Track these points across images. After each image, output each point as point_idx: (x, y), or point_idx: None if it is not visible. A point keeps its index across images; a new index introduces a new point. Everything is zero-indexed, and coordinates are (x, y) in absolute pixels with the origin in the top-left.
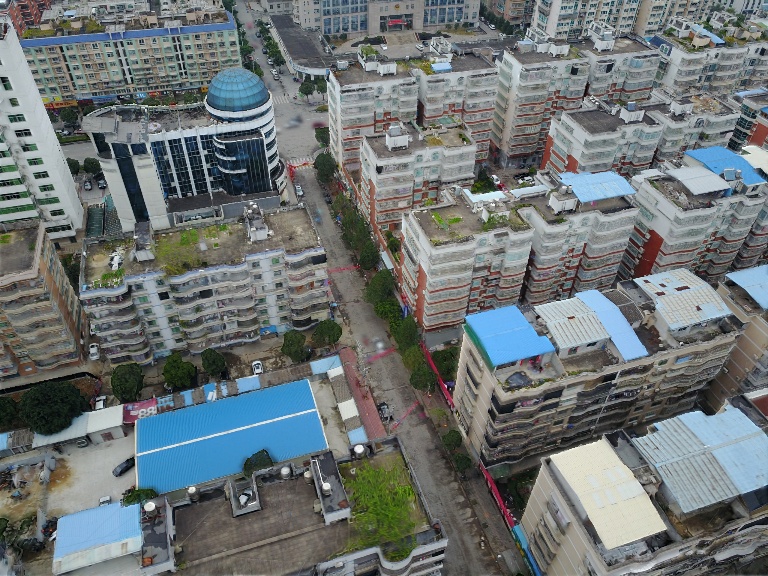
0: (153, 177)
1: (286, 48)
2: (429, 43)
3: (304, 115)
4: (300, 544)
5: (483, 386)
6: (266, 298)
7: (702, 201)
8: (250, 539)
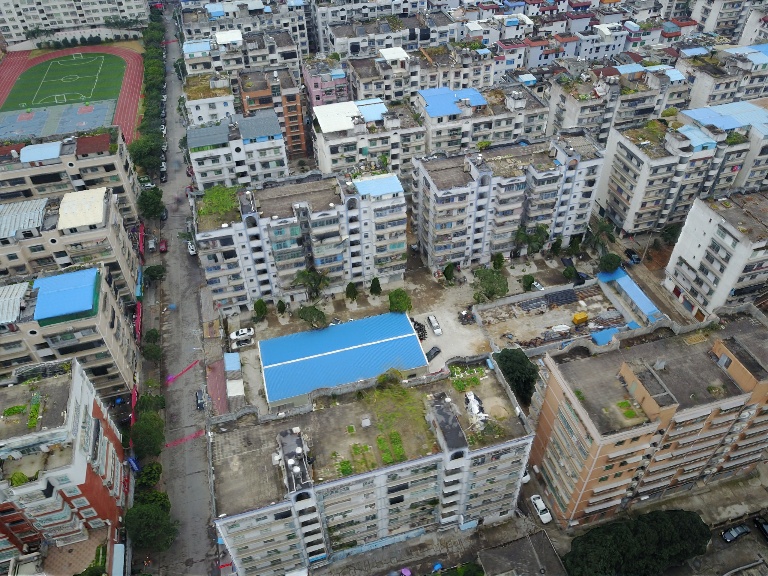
0: None
1: None
2: None
3: None
4: (271, 195)
5: None
6: None
7: None
8: (298, 197)
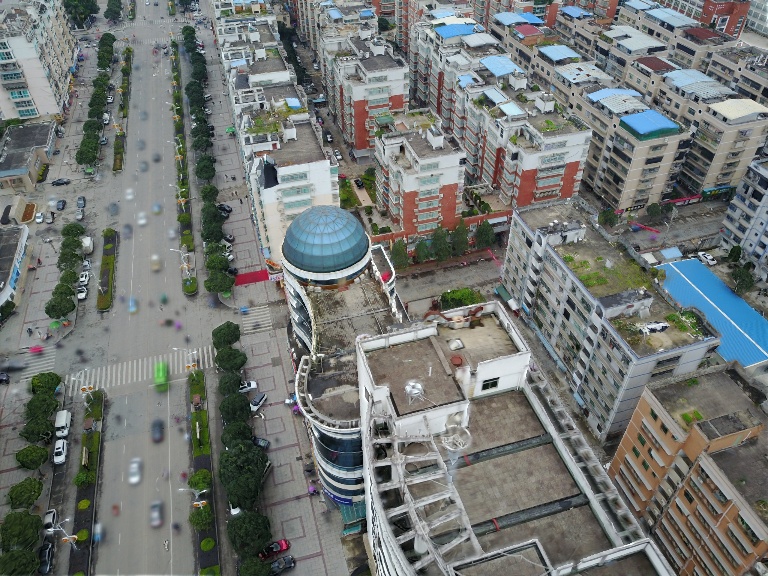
0: None
1: None
2: None
3: (113, 324)
4: None
5: (665, 154)
6: None
7: (492, 48)
8: None
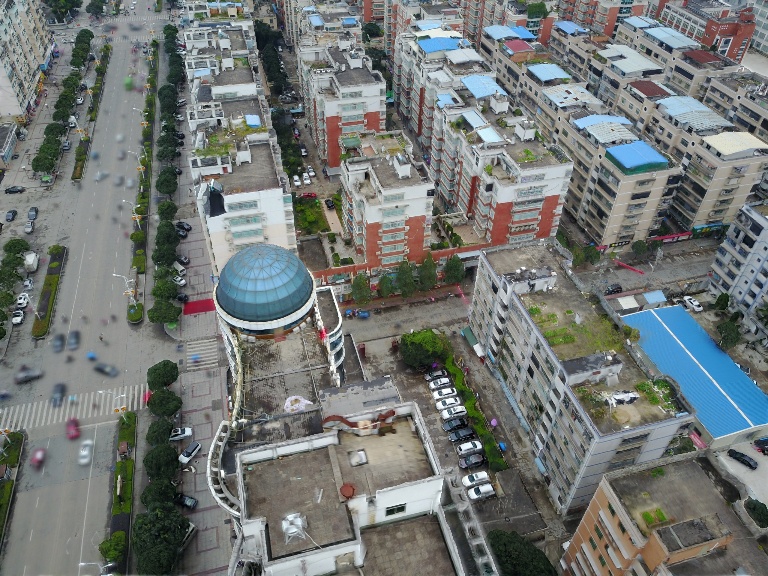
0: None
1: None
2: None
3: (46, 354)
4: None
5: (653, 189)
6: None
7: (477, 65)
8: None
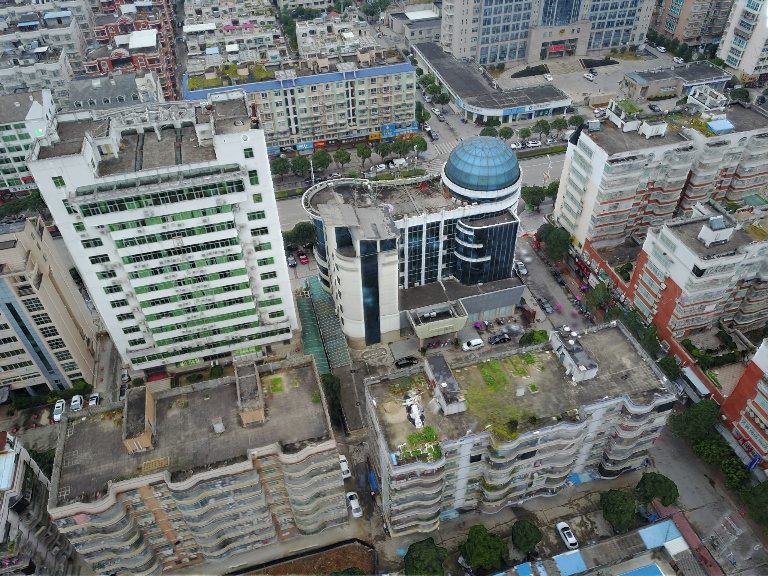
0: (395, 274)
1: (448, 84)
2: (597, 71)
3: None
4: None
5: None
6: (581, 447)
7: None
8: None
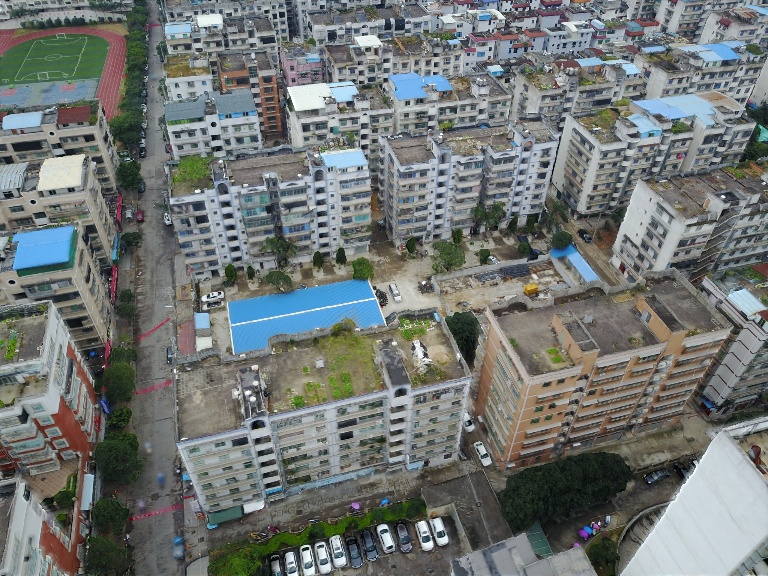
0: None
1: None
2: None
3: None
4: (243, 166)
5: None
6: None
7: None
8: (269, 168)
